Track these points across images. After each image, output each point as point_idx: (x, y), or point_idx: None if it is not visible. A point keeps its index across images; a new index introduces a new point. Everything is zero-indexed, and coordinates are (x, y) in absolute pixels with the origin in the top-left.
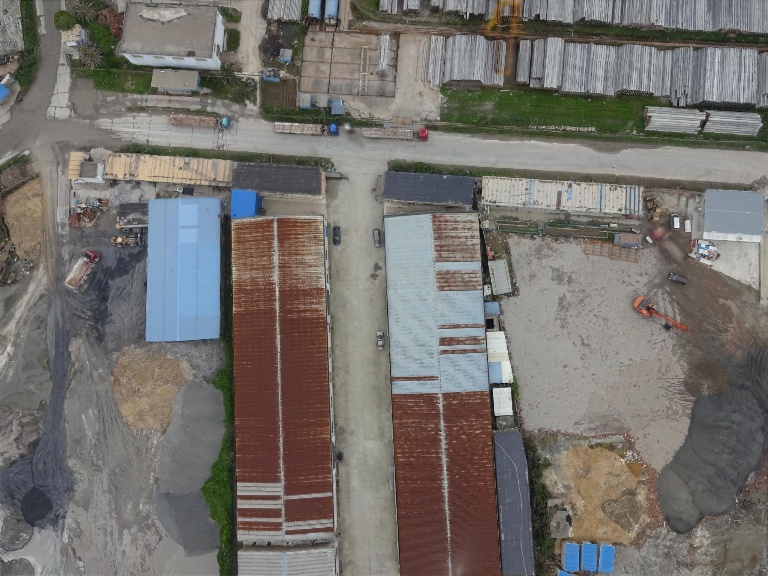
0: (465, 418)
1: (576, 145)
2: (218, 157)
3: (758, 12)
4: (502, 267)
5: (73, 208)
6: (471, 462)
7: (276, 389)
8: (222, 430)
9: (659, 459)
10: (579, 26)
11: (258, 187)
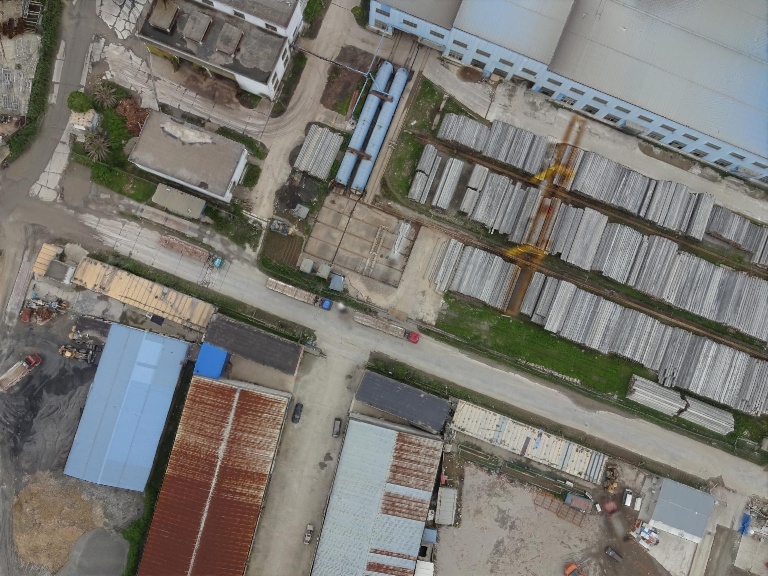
0: None
1: (558, 392)
2: (200, 294)
3: (761, 317)
4: (451, 497)
5: (28, 300)
6: None
7: (186, 569)
8: None
9: None
10: (595, 275)
11: (231, 348)
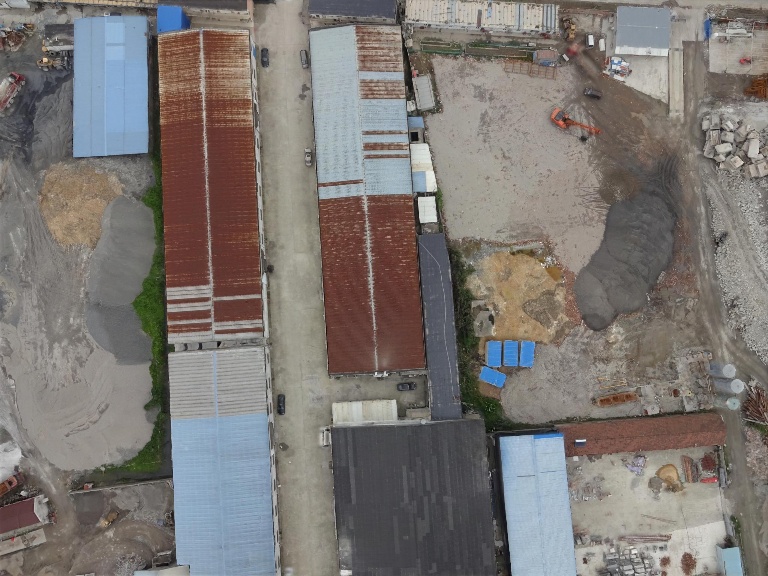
0: (389, 219)
1: None
2: None
3: None
4: (426, 83)
5: None
6: (396, 261)
7: (204, 195)
8: (153, 246)
9: (576, 262)
10: None
11: (184, 3)
